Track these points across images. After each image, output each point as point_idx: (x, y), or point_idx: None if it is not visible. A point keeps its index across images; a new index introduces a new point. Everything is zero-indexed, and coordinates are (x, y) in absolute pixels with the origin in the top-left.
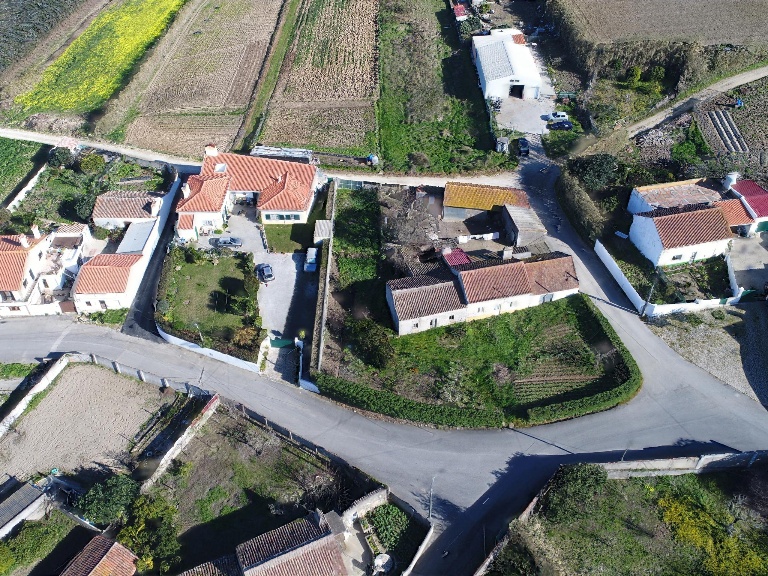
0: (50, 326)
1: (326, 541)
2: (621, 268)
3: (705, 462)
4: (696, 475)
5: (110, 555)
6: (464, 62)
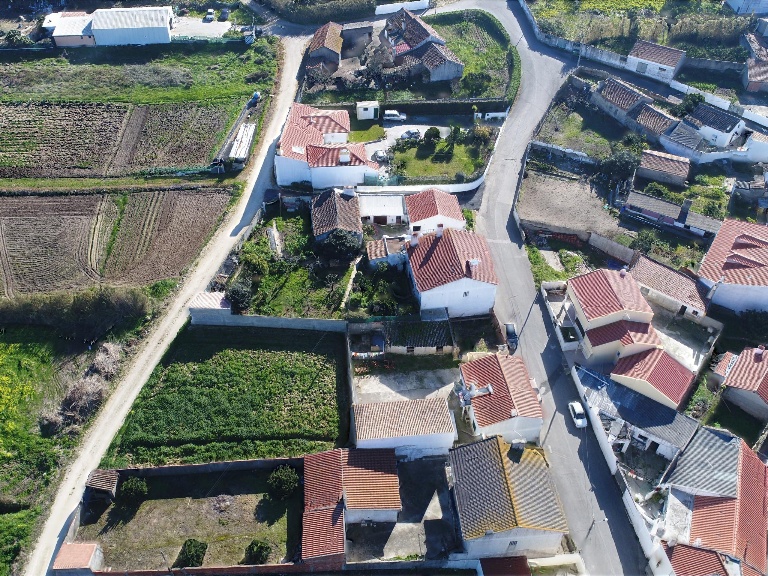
0: None
1: (614, 79)
2: None
3: None
4: None
5: None
6: (88, 51)
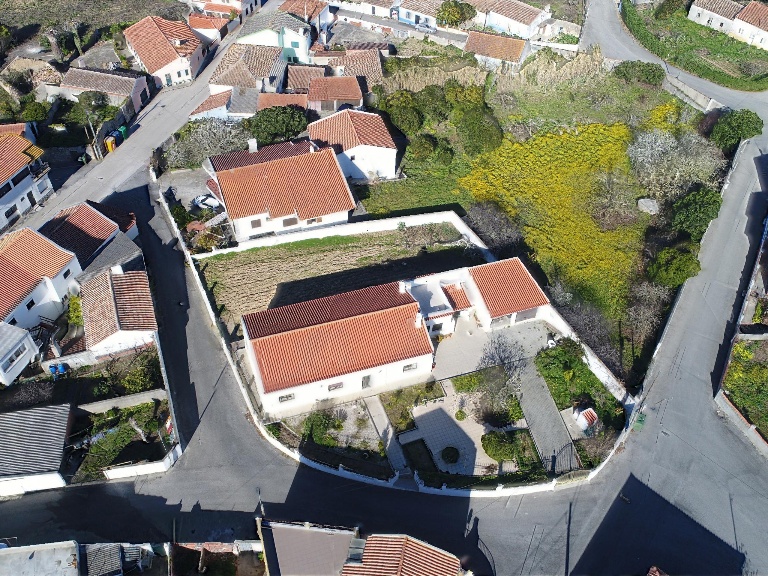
0: None
1: (537, 10)
2: None
3: (712, 106)
4: (703, 113)
5: None
6: None
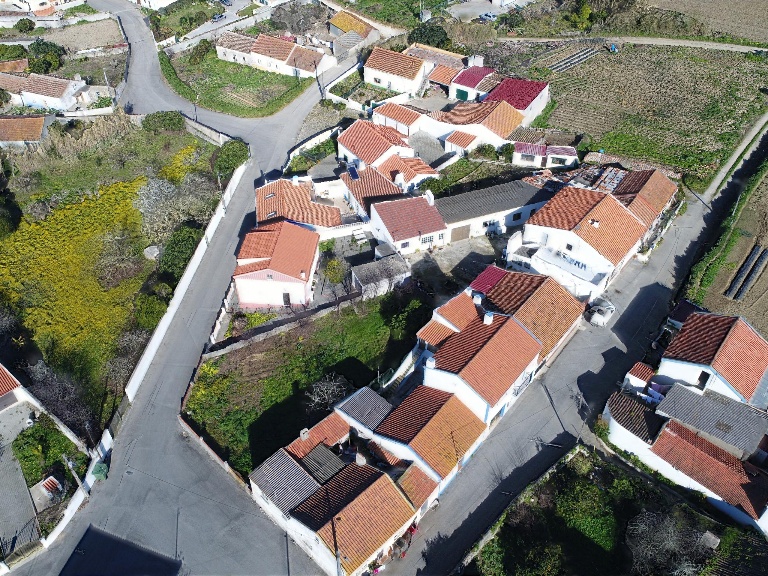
0: (127, 6)
1: (65, 81)
2: (353, 78)
3: (223, 140)
4: None
5: (22, 61)
6: None
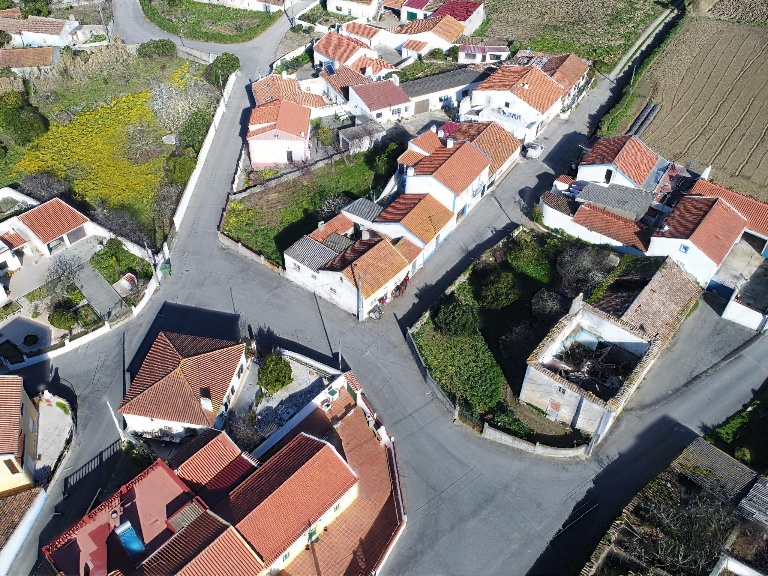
0: None
1: (62, 21)
2: (317, 9)
3: (213, 59)
4: None
5: (14, 9)
6: None
